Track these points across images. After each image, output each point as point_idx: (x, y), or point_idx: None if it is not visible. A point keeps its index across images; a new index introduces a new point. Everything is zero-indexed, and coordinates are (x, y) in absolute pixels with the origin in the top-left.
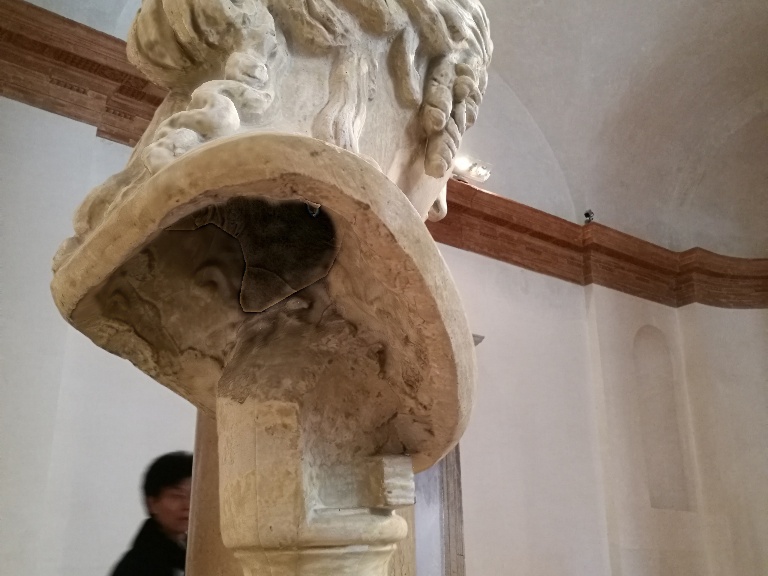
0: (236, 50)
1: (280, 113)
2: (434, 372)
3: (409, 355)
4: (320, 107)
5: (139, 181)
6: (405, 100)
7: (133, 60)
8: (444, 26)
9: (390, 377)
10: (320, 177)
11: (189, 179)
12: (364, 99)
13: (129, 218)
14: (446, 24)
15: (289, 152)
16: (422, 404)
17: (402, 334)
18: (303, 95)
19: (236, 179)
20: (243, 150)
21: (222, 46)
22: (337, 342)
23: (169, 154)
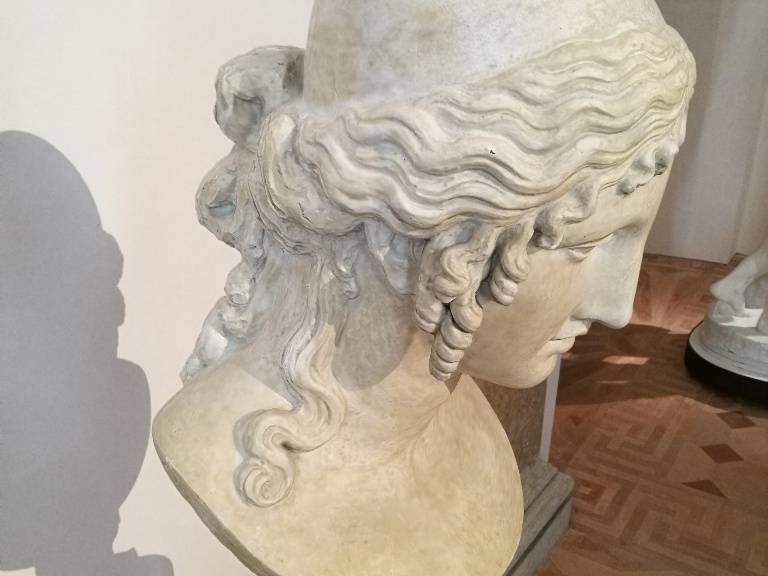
0: None
1: (267, 326)
2: None
3: None
4: (299, 316)
5: None
6: None
7: None
8: (394, 222)
9: None
10: None
11: None
12: (324, 315)
13: None
14: (398, 218)
15: None
16: None
17: None
18: (288, 302)
19: None
20: None
21: None
22: None
23: (184, 379)
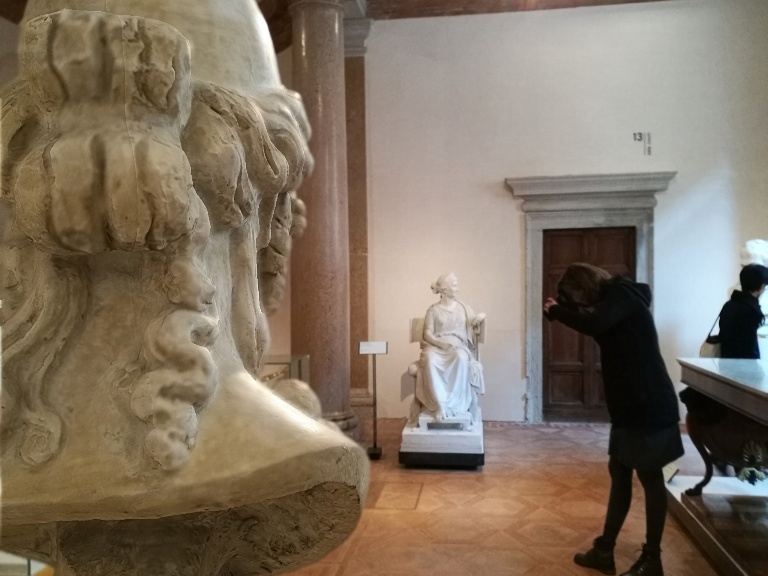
0: (179, 256)
1: None
2: (312, 552)
3: (291, 537)
4: (229, 299)
5: (44, 396)
6: (258, 247)
7: (28, 232)
8: (301, 175)
9: (255, 542)
10: (338, 480)
11: (232, 496)
12: None
13: (120, 506)
14: (302, 171)
15: (324, 466)
16: (280, 561)
17: (293, 525)
18: (219, 289)
19: (278, 495)
20: (291, 471)
21: (163, 249)
22: (213, 518)
23: (186, 450)
